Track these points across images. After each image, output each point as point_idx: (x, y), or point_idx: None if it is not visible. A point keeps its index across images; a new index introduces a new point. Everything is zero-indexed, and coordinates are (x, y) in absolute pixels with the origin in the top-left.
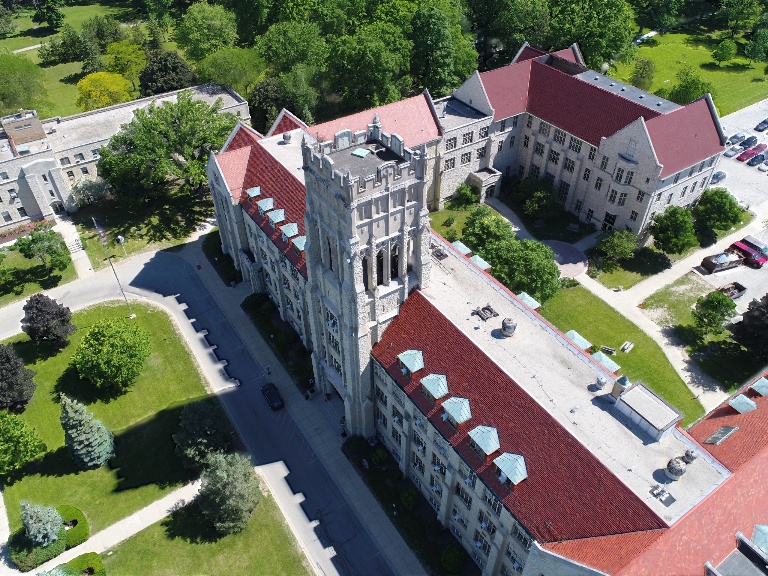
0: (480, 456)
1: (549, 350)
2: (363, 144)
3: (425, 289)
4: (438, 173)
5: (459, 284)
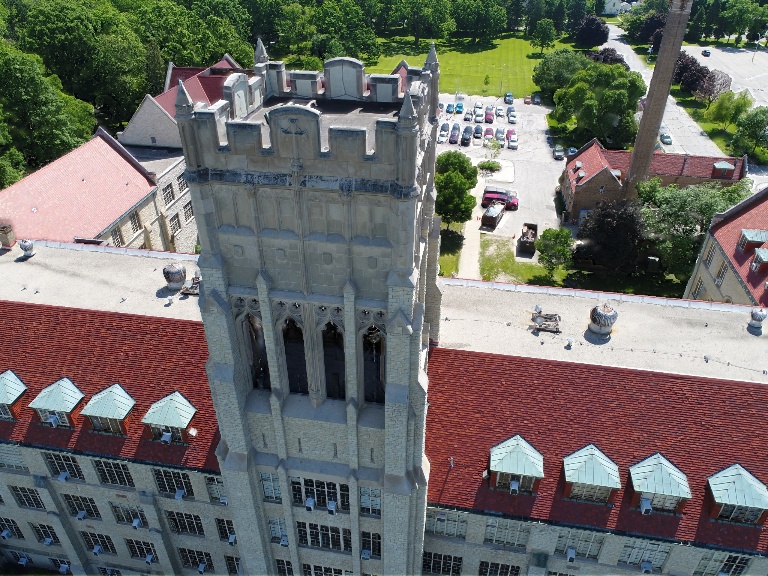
0: (746, 523)
1: (661, 320)
2: (261, 108)
3: (439, 340)
4: (167, 241)
5: (463, 310)
